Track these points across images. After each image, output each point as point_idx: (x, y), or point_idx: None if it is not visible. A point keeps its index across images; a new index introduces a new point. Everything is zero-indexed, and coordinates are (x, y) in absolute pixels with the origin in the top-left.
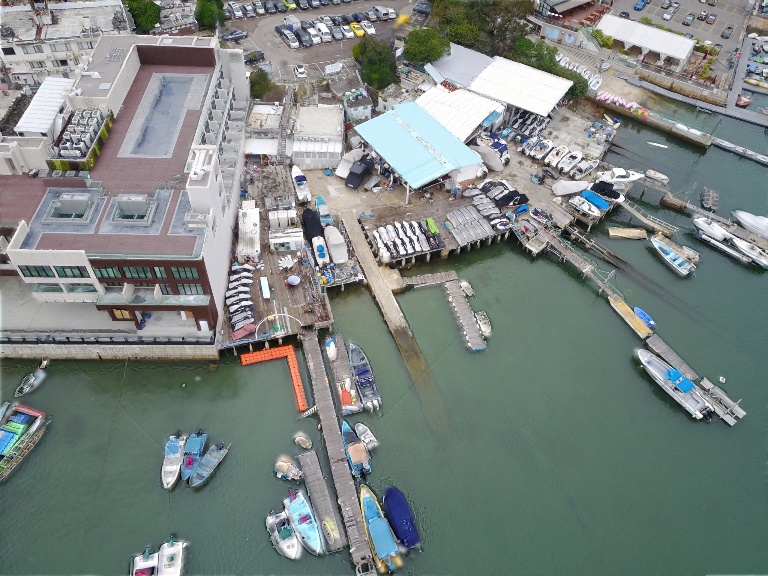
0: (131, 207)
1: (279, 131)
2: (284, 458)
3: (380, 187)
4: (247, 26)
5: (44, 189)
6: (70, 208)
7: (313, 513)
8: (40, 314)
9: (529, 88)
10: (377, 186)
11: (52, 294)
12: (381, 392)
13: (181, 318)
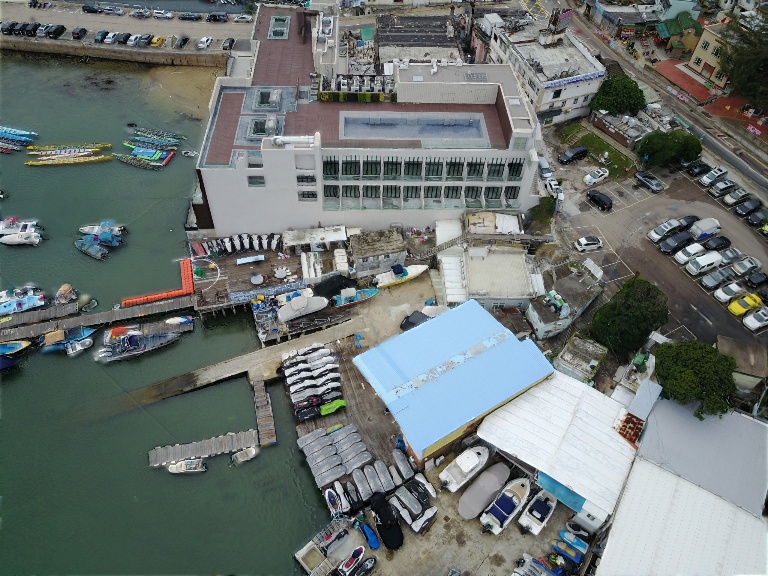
0: None
1: (460, 236)
2: (82, 295)
3: None
4: (684, 192)
5: None
6: None
7: (22, 312)
8: None
9: (678, 574)
10: None
11: None
12: (127, 365)
13: None
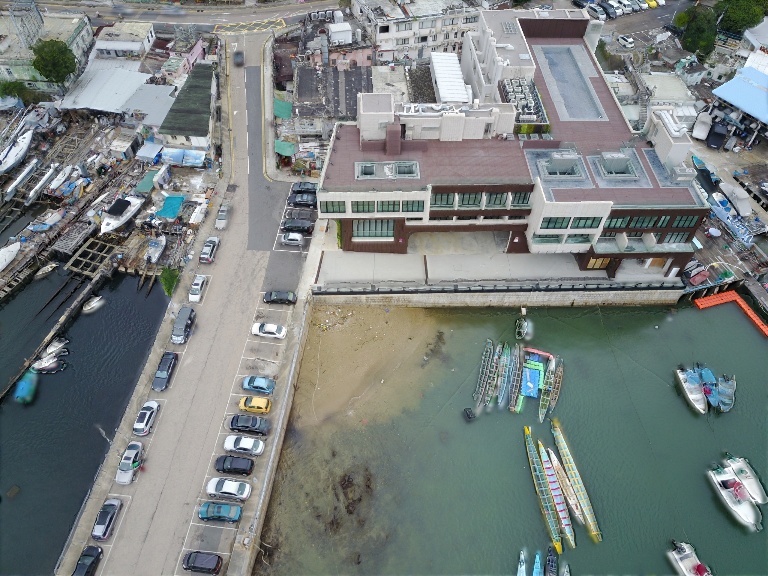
0: (613, 164)
1: (640, 97)
2: None
3: (739, 147)
4: (543, 1)
5: (521, 151)
6: (557, 166)
7: None
8: (513, 266)
9: None
10: (736, 146)
11: (550, 245)
12: None
13: (643, 267)
